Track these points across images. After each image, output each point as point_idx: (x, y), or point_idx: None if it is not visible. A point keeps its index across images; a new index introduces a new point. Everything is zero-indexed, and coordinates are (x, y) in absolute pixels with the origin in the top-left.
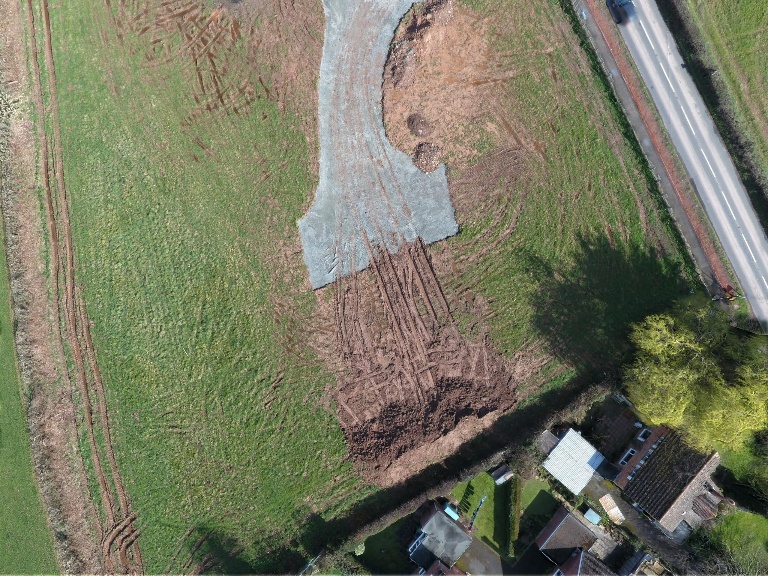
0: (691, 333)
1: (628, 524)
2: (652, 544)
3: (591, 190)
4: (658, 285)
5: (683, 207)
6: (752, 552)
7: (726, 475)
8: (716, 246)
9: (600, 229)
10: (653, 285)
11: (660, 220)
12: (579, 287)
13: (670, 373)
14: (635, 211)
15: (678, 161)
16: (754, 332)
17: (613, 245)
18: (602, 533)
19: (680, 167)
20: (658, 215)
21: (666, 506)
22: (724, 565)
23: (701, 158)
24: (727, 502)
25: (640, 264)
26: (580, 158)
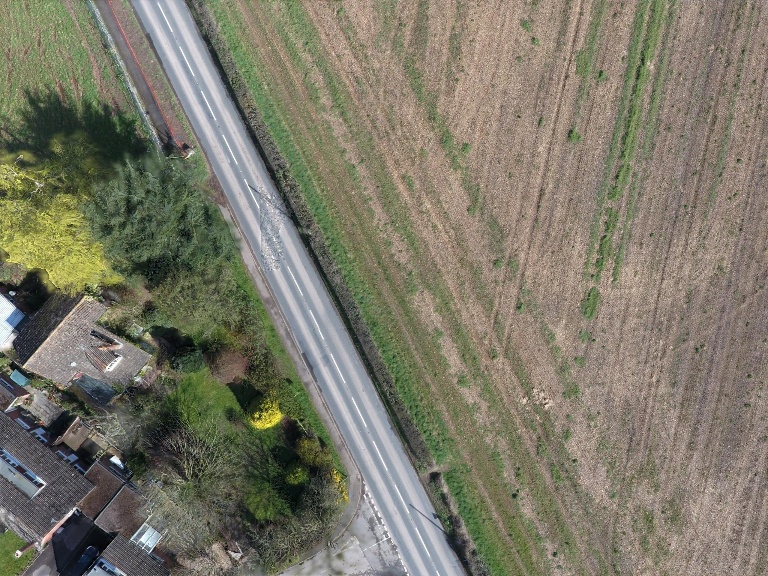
0: (49, 169)
1: (75, 390)
2: (101, 411)
3: (40, 45)
4: (112, 144)
5: (136, 62)
6: (211, 420)
7: (184, 340)
8: (171, 103)
9: (50, 86)
10: (107, 144)
11: (115, 77)
12: (28, 146)
13: (3, 205)
14: (88, 67)
15: (131, 15)
16: (214, 193)
17: (65, 103)
18: (47, 399)
19: (134, 21)
20: (113, 72)
21: (33, 352)
22: (112, 417)
23: (157, 12)
24: (166, 364)
25: (93, 122)
26: (29, 12)
